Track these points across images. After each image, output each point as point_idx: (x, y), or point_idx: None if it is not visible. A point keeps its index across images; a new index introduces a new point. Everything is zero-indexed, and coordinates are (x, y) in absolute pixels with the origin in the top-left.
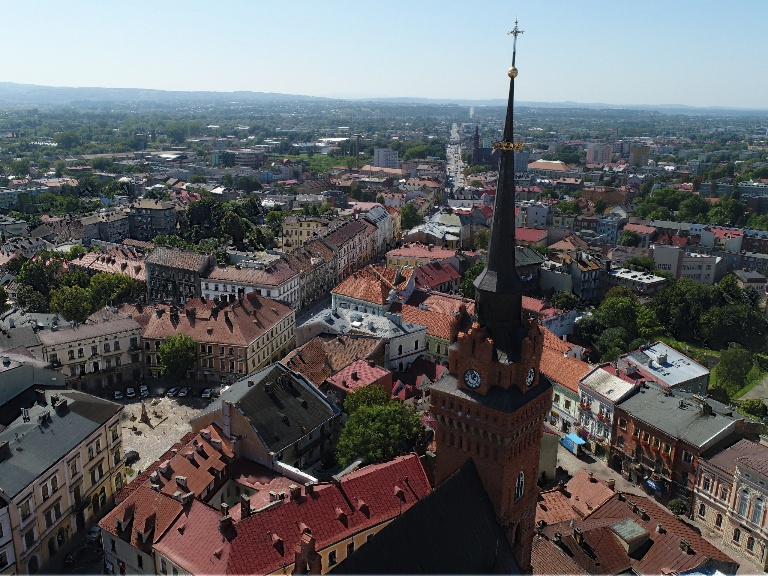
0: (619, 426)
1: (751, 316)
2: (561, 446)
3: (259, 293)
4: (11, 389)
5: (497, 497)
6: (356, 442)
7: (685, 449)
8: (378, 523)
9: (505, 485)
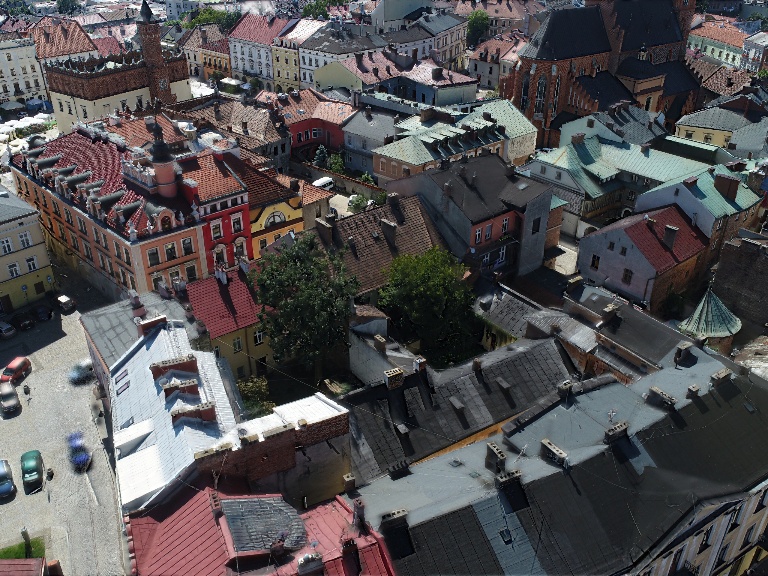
0: (765, 62)
1: None
2: None
3: None
4: (413, 6)
5: None
6: None
7: None
8: None
9: None
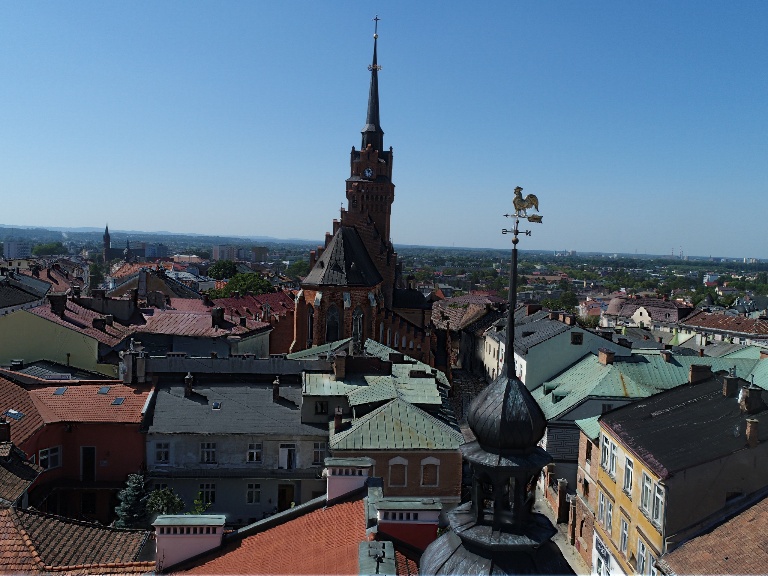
0: None
1: None
2: None
3: None
4: None
5: (383, 230)
6: (243, 288)
7: None
8: None
9: None
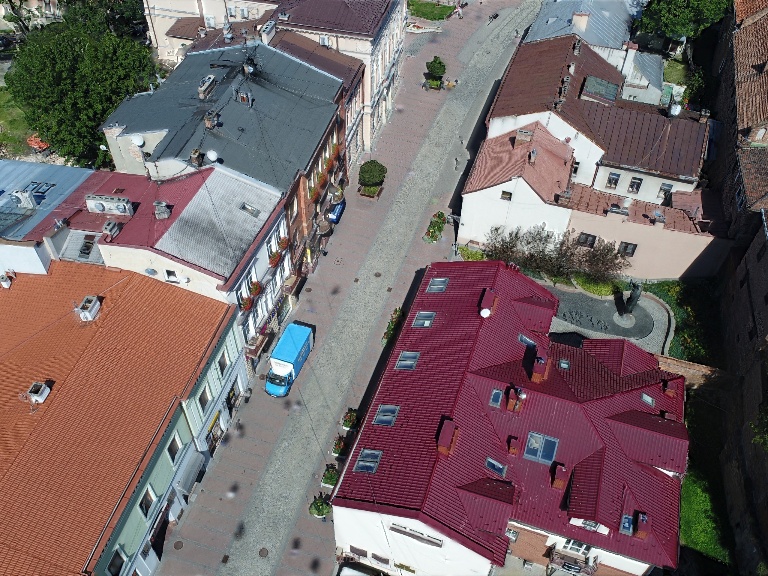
0: None
1: None
2: (294, 390)
3: None
4: None
5: None
6: None
7: None
8: None
9: None
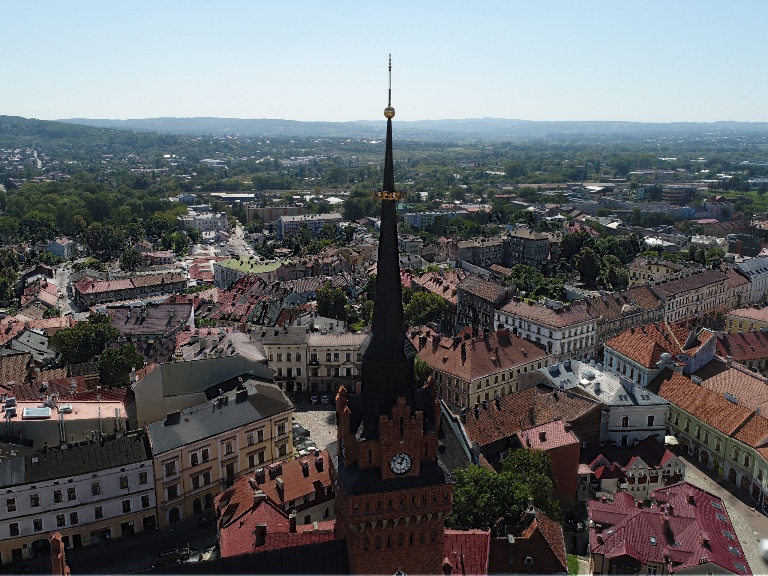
0: None
1: None
2: None
3: (515, 331)
4: (227, 373)
5: None
6: None
7: None
8: None
9: None
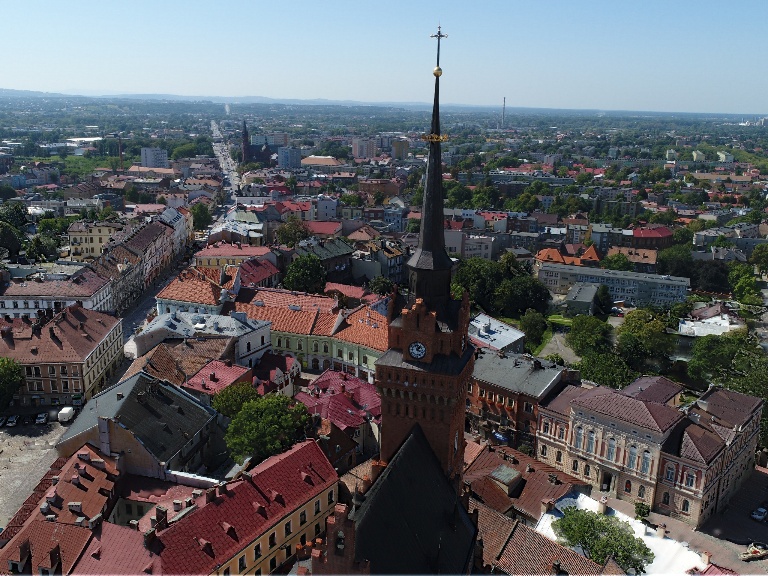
0: None
1: (535, 285)
2: None
3: (80, 305)
4: None
5: (444, 454)
6: (252, 437)
7: (526, 401)
8: (295, 509)
9: (450, 442)
